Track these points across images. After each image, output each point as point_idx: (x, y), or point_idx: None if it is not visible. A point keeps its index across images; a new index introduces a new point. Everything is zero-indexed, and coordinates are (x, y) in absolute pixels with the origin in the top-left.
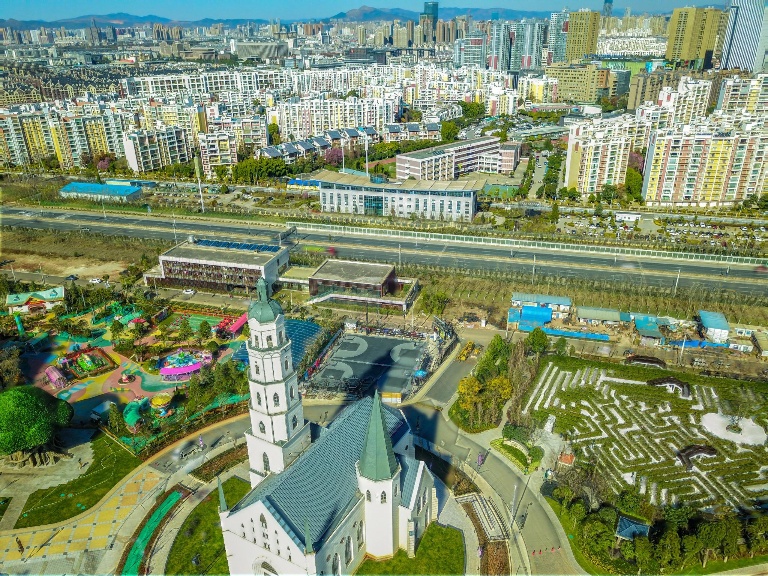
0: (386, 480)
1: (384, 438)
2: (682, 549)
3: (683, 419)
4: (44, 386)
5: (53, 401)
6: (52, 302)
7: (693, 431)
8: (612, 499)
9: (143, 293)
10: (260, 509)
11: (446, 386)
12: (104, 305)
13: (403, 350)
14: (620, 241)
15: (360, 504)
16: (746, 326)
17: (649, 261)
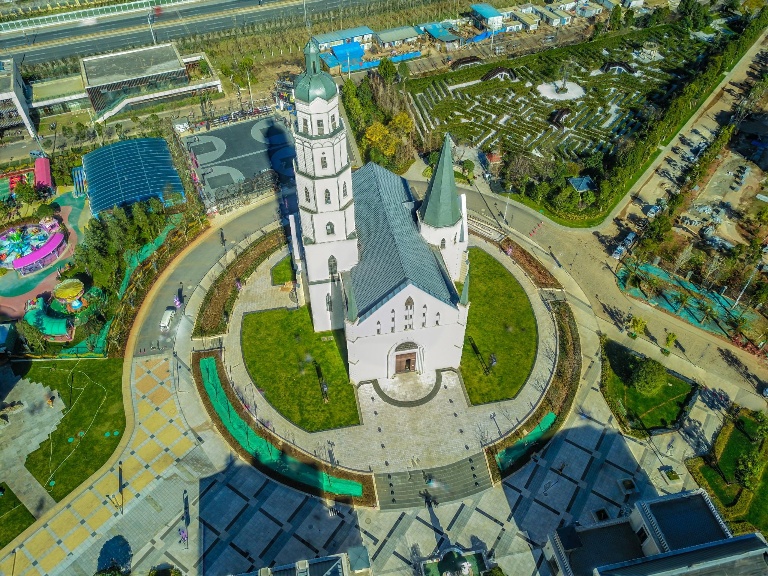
0: (459, 221)
1: None
2: None
3: (529, 97)
4: None
5: None
6: None
7: (543, 103)
8: None
9: None
10: (408, 293)
11: None
12: None
13: (263, 130)
14: None
15: None
16: (505, 9)
17: None
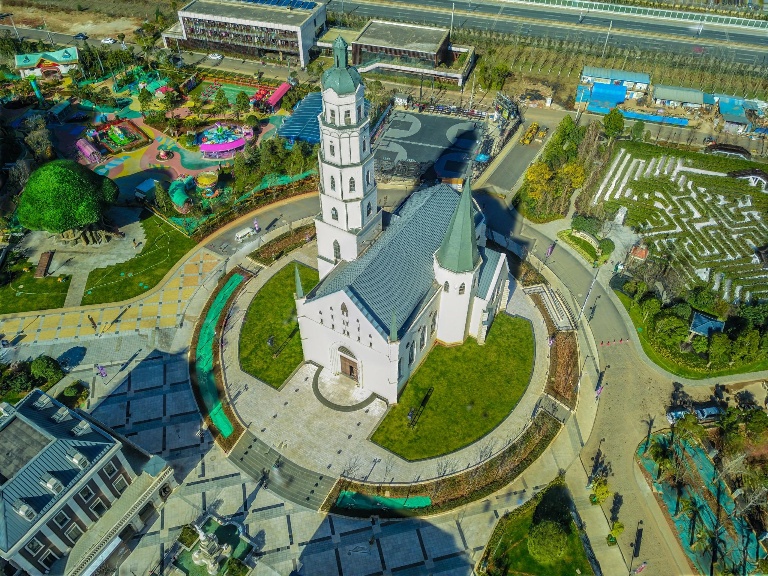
0: (468, 272)
1: (470, 229)
2: (760, 346)
3: (764, 215)
4: (78, 160)
5: (96, 178)
6: (66, 65)
7: None
8: (685, 295)
9: (166, 57)
10: (342, 298)
11: (508, 172)
12: (124, 70)
13: (460, 131)
14: (705, 6)
15: (437, 295)
16: None
17: (738, 32)
